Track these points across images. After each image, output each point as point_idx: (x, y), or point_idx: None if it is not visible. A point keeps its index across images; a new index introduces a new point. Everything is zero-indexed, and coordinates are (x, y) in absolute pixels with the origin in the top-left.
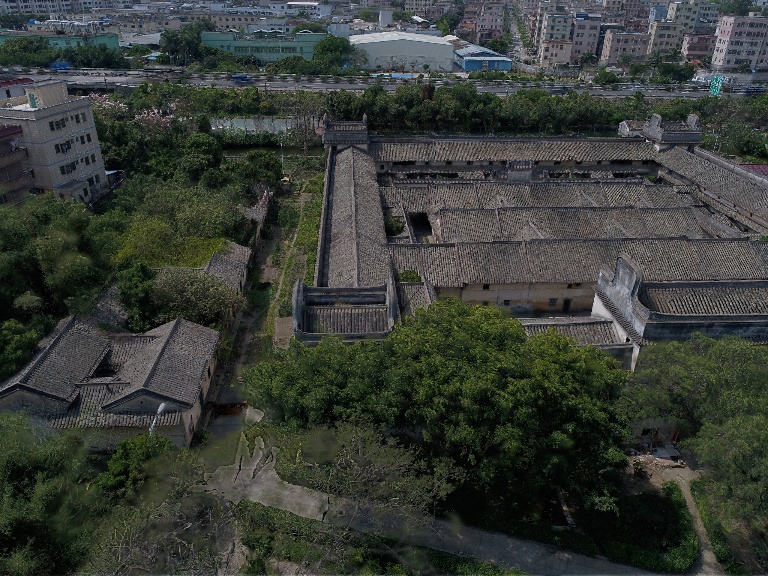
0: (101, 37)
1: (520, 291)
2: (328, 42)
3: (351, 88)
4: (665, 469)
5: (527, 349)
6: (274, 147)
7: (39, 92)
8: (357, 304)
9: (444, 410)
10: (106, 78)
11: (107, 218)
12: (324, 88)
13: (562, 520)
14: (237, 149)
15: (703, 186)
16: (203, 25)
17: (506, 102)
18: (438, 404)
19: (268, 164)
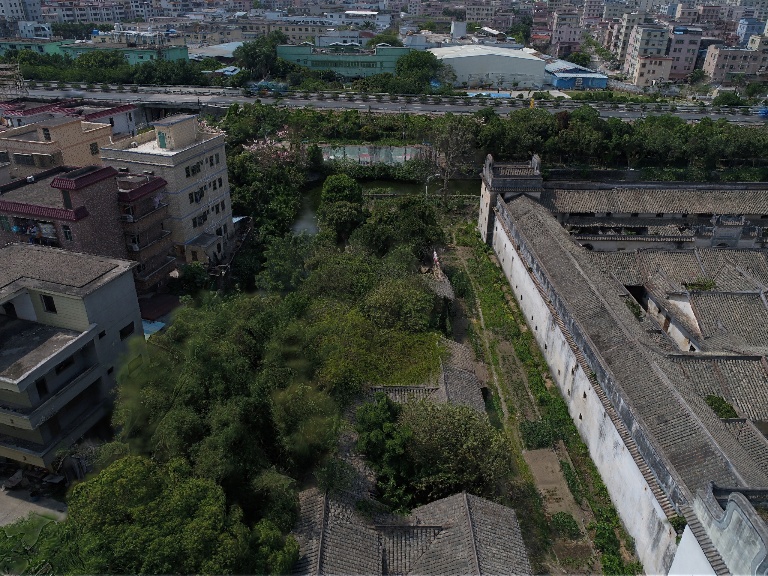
0: (173, 50)
1: None
2: (415, 57)
3: (457, 111)
4: None
5: None
6: (391, 181)
7: (171, 130)
8: None
9: None
10: (190, 97)
11: (325, 325)
12: (428, 111)
13: None
14: None
15: None
16: (277, 37)
17: (641, 130)
18: None
19: (423, 214)
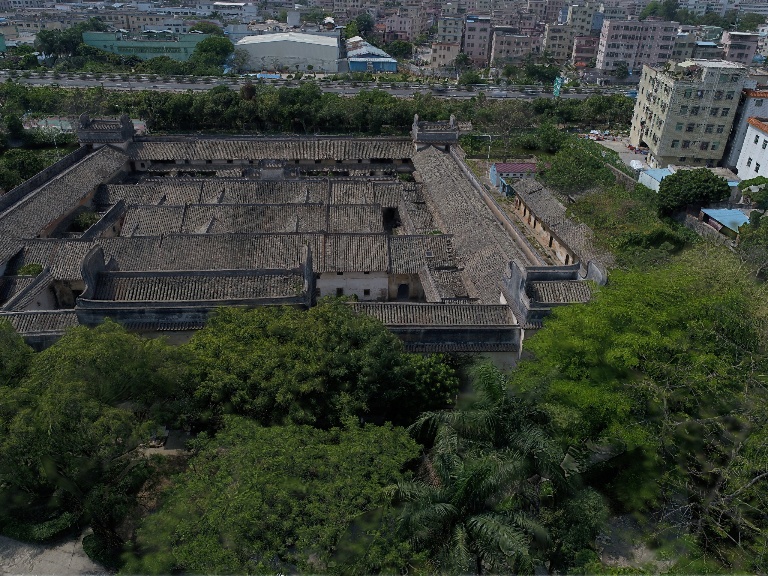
0: None
1: None
2: (205, 43)
3: (199, 88)
4: (139, 449)
5: None
6: None
7: None
8: None
9: None
10: None
11: None
12: (172, 88)
13: None
14: (50, 148)
15: (423, 184)
16: (90, 25)
17: (339, 102)
18: None
19: None
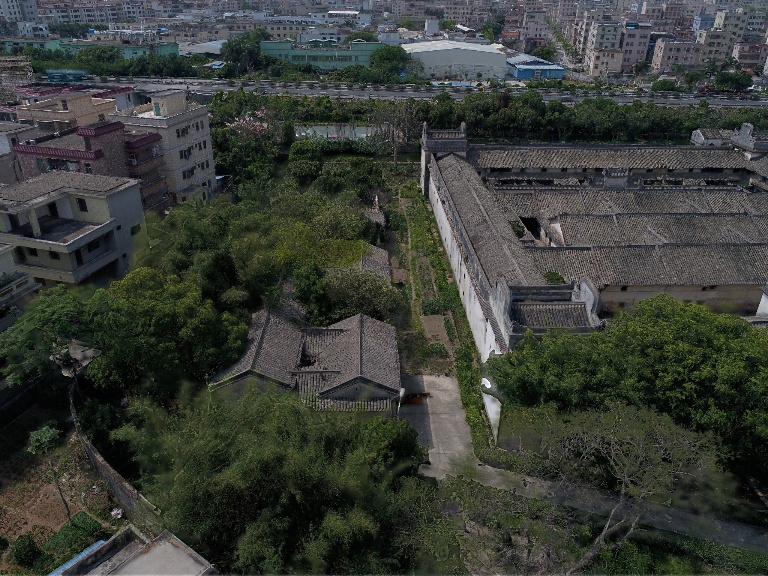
0: (165, 46)
1: (656, 293)
2: (386, 51)
3: (418, 96)
4: None
5: (761, 342)
6: (355, 154)
7: (164, 101)
8: (545, 301)
9: (695, 395)
10: (180, 86)
11: None
12: (392, 96)
13: (761, 505)
14: None
15: None
16: (260, 34)
17: (575, 110)
18: (691, 390)
19: (371, 170)
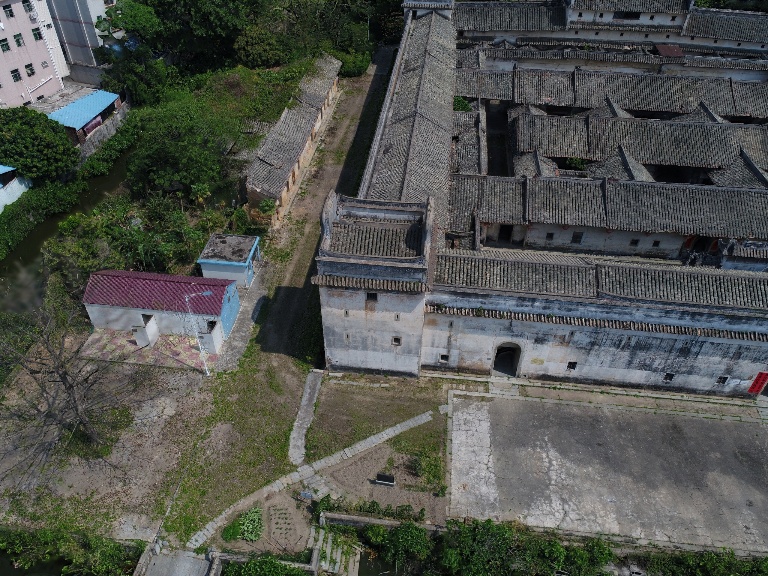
0: None
1: None
2: None
3: None
4: None
5: None
6: None
7: None
8: None
9: None
10: None
11: None
12: None
13: None
14: None
15: None
16: None
17: None
18: None
19: None
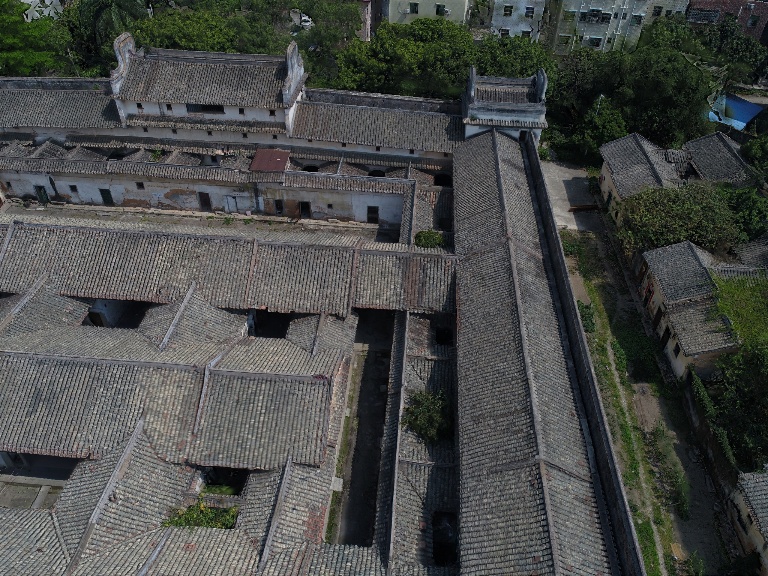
0: None
1: None
2: None
3: None
4: None
5: None
6: None
7: None
8: None
9: None
10: None
11: None
12: None
13: None
14: None
15: None
16: None
17: None
18: None
19: None
